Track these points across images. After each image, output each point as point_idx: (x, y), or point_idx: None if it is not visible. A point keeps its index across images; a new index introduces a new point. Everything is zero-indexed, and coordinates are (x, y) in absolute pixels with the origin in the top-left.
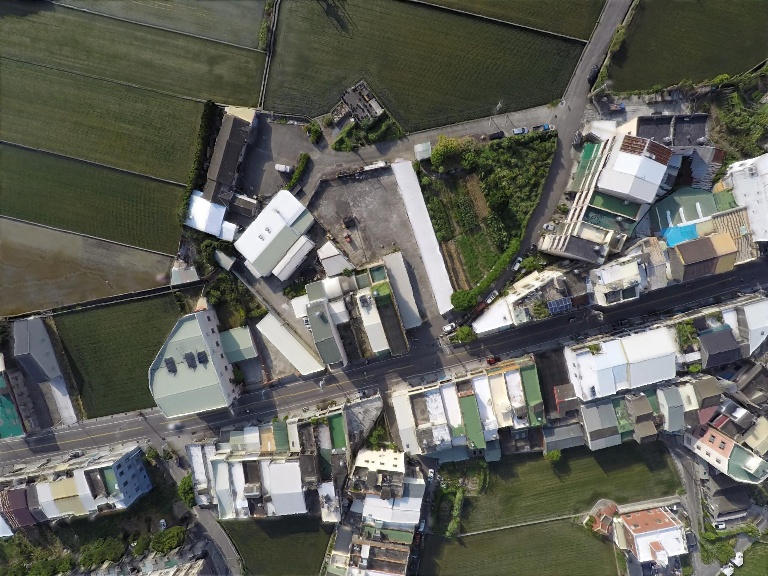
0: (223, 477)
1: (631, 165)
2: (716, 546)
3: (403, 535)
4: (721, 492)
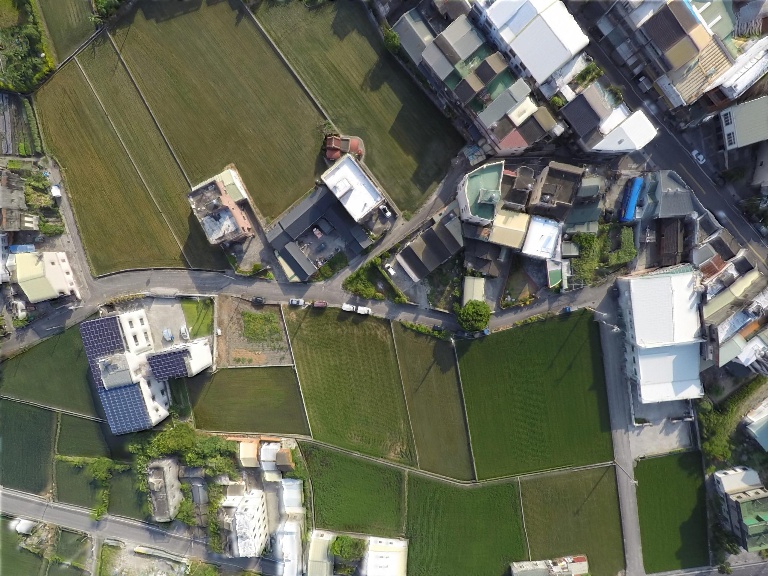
0: None
1: None
2: (367, 283)
3: None
4: (429, 239)
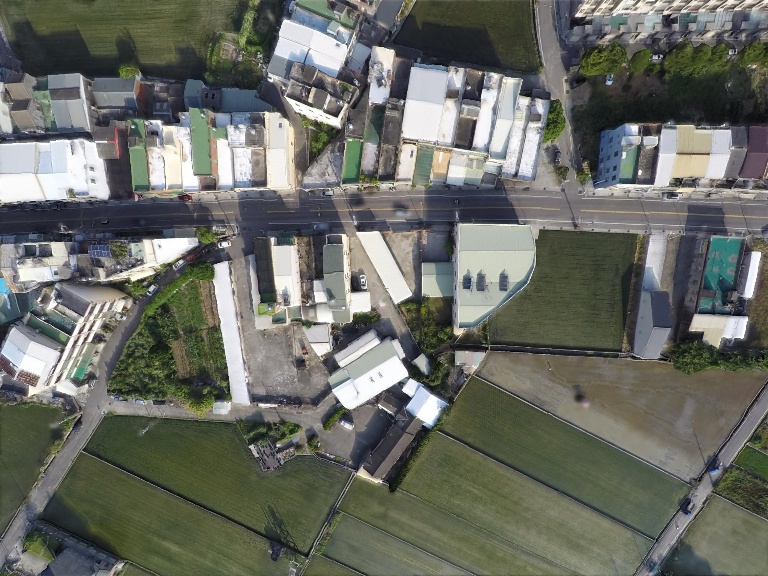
0: (500, 135)
1: (29, 363)
2: None
3: (309, 3)
4: None
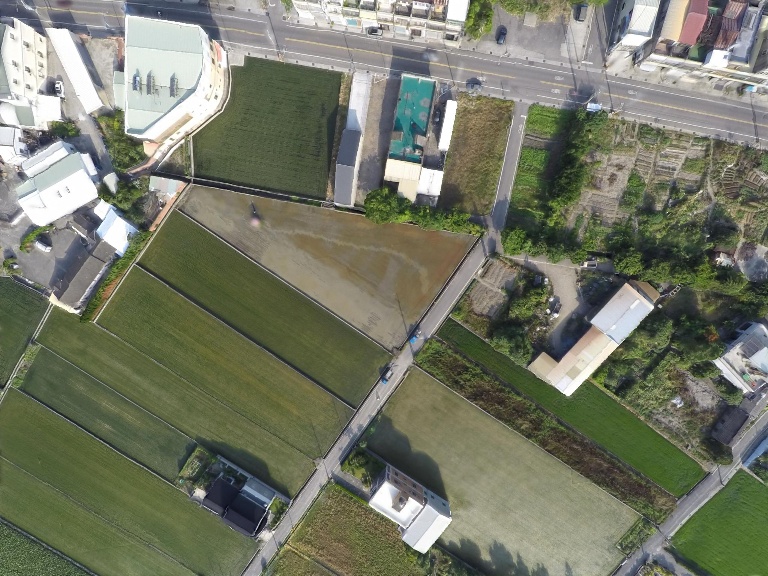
0: None
1: None
2: None
3: None
4: None
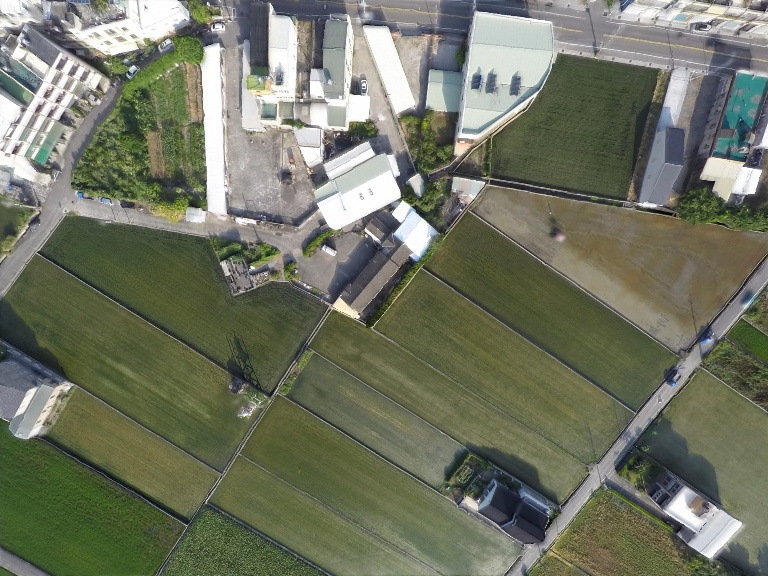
0: None
1: None
2: None
3: None
4: None
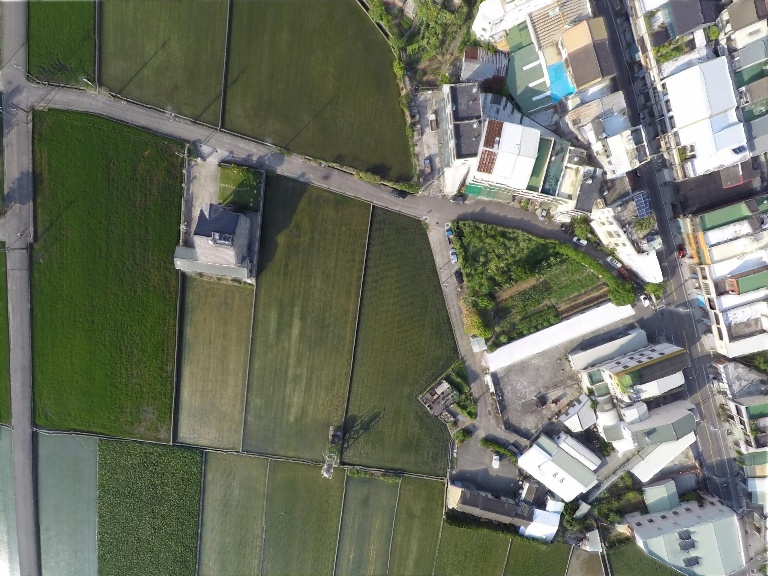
0: None
1: (507, 161)
2: None
3: None
4: None
